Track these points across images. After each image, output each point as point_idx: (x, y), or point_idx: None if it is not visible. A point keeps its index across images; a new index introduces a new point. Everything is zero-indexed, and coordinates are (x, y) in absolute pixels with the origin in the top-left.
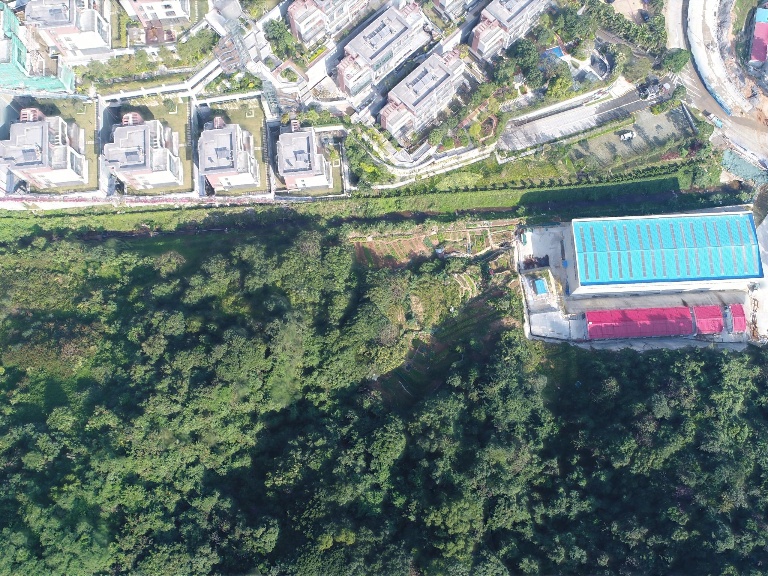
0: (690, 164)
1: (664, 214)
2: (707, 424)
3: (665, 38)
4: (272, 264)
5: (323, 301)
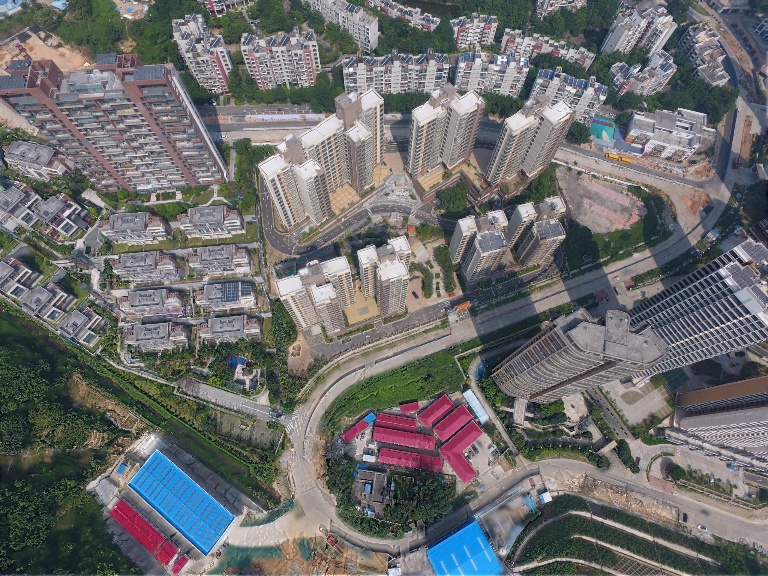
0: None
1: (197, 482)
2: None
3: (293, 394)
4: (4, 366)
5: (7, 399)
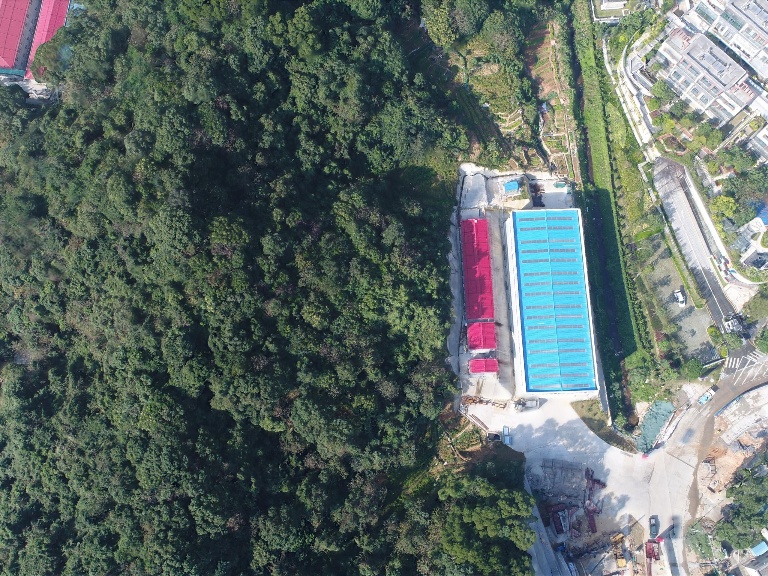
0: (653, 360)
1: None
2: (377, 275)
3: None
4: None
5: None
